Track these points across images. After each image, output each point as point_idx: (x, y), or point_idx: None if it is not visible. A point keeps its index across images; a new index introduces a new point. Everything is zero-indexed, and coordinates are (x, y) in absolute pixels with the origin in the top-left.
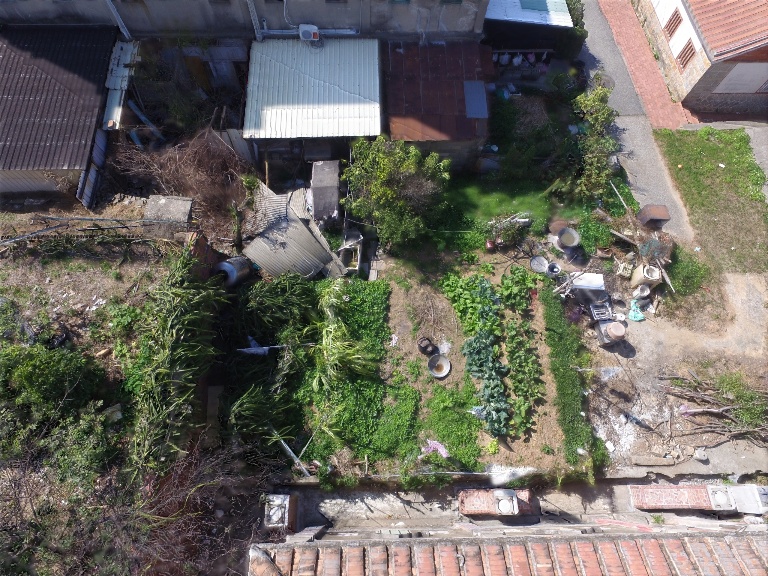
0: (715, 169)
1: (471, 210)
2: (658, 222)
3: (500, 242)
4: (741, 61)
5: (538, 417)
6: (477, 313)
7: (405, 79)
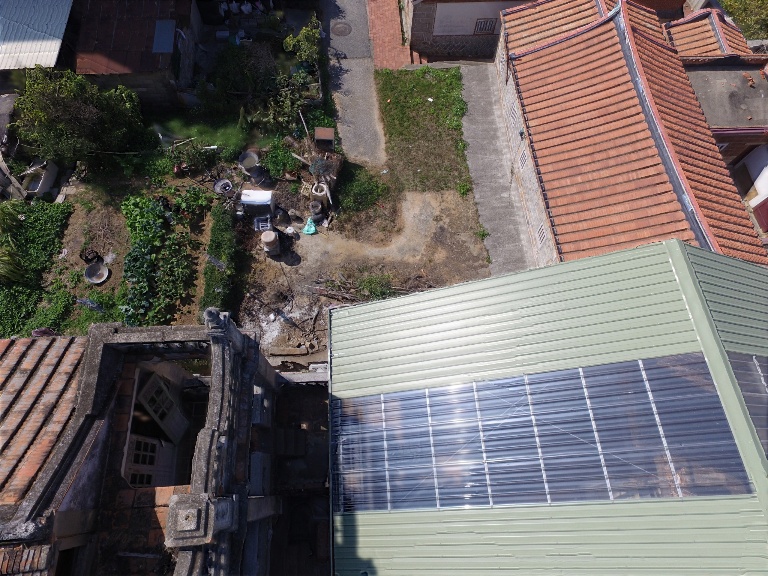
0: (423, 103)
1: (170, 141)
2: (331, 144)
3: (185, 166)
4: (438, 1)
5: (181, 315)
6: (140, 226)
7: (100, 20)
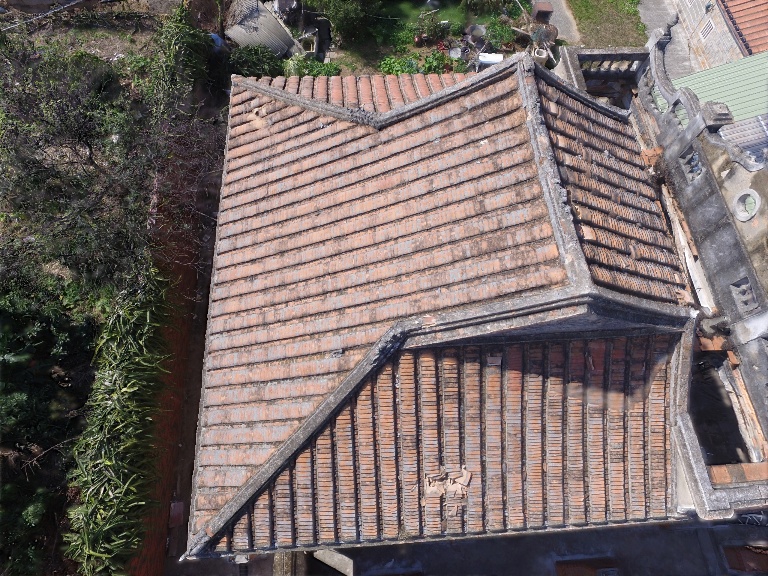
0: None
1: (404, 19)
2: (546, 17)
3: (425, 36)
4: None
5: None
6: None
7: None
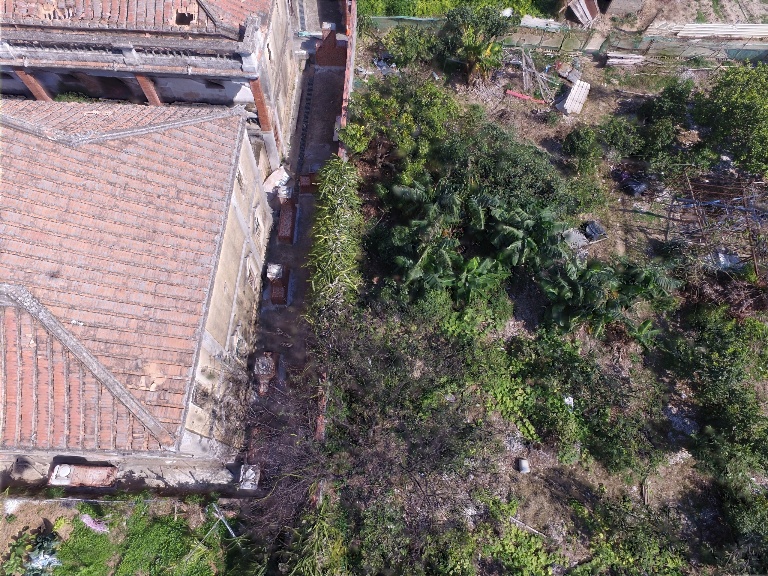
0: None
1: None
2: None
3: None
4: None
5: (4, 552)
6: None
7: None
